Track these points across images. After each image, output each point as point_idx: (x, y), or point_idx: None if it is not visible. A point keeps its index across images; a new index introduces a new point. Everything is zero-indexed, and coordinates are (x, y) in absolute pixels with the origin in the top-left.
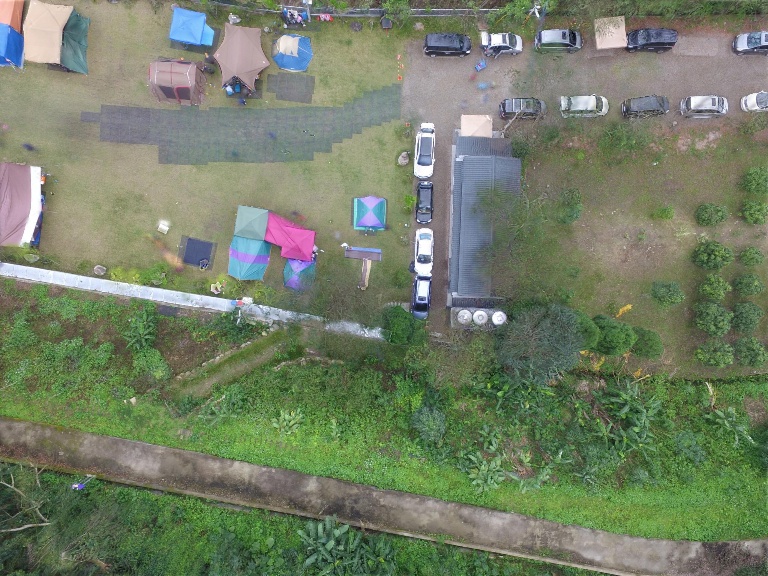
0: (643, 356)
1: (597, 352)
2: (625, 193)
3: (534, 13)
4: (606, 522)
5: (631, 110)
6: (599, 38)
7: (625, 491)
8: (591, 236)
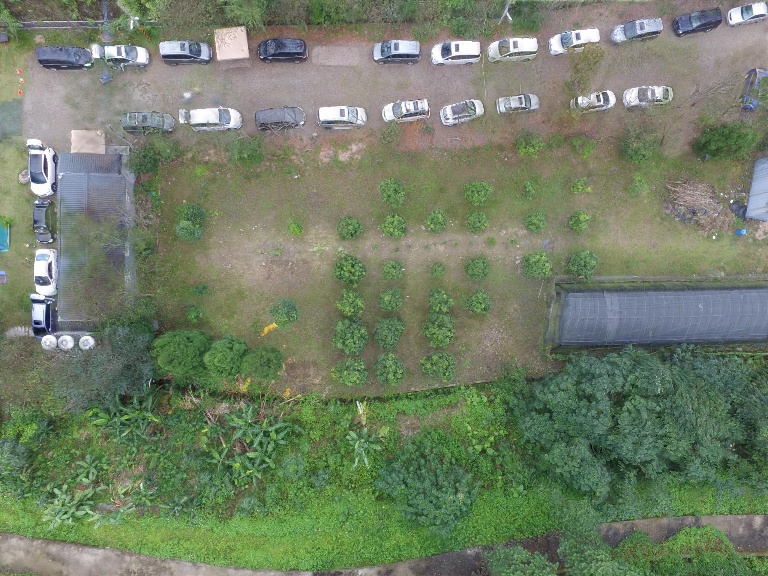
0: (291, 376)
1: (242, 373)
2: (266, 207)
3: (156, 24)
4: (210, 554)
5: (257, 122)
6: (218, 49)
7: (229, 521)
8: (227, 253)
